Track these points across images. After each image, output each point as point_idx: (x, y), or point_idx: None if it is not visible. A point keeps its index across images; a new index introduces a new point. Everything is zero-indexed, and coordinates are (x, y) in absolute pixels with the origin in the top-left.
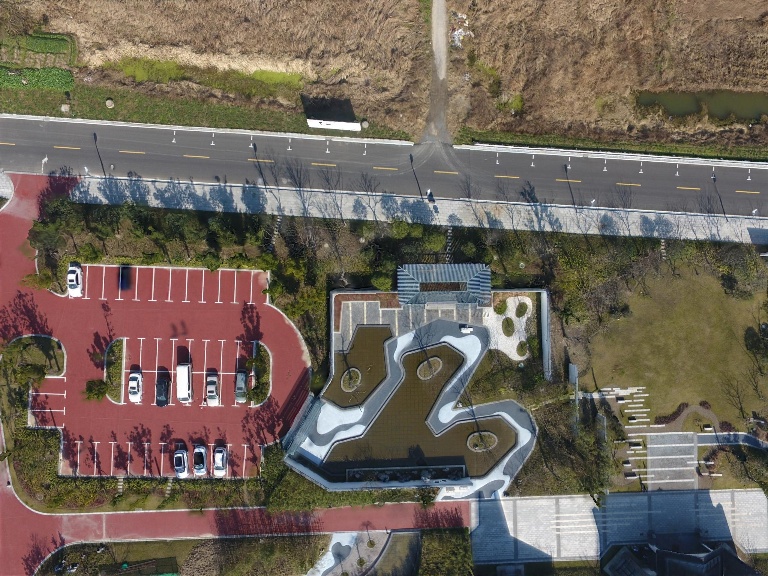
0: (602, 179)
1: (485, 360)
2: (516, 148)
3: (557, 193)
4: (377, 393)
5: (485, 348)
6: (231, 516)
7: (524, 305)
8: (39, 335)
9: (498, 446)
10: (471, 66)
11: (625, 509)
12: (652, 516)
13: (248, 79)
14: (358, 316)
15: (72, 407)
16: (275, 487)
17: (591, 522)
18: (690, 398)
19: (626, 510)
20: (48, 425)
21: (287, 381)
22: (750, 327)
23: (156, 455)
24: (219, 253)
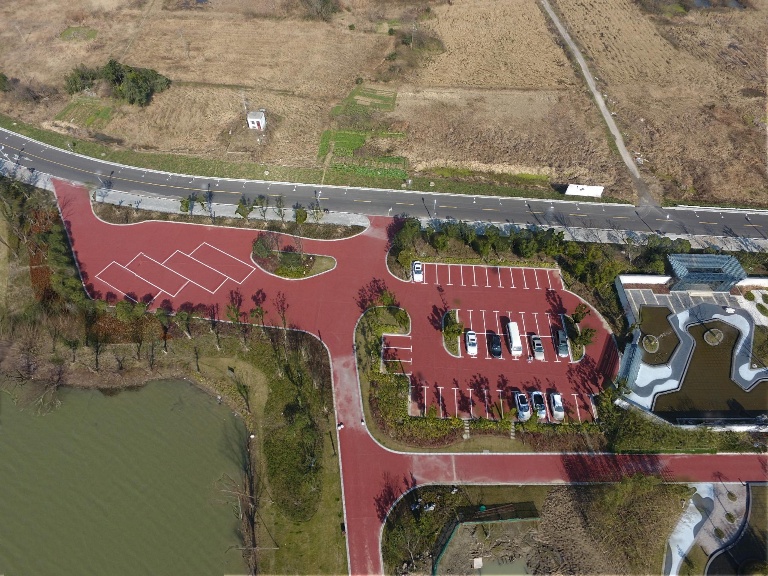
0: None
1: (757, 332)
2: (706, 208)
3: (749, 232)
4: (677, 354)
5: (752, 324)
6: (578, 461)
7: (767, 296)
8: (389, 306)
9: None
10: (654, 173)
11: None
12: None
13: (515, 177)
14: (638, 299)
15: (418, 358)
16: (619, 426)
17: None
18: None
19: None
20: (398, 372)
21: (596, 343)
22: None
23: (495, 400)
24: (520, 258)
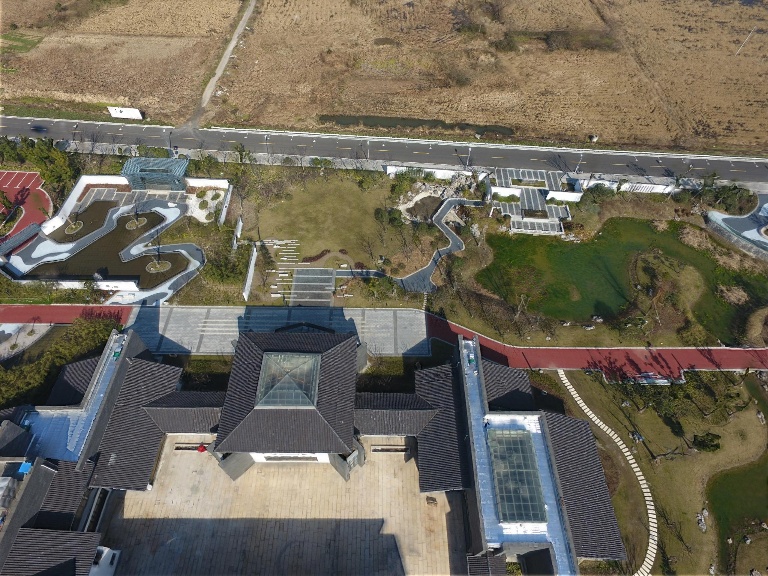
0: (288, 143)
1: (180, 221)
2: (237, 130)
3: (258, 148)
4: (90, 236)
5: (182, 215)
6: None
7: (219, 195)
8: None
9: (171, 270)
10: (223, 103)
11: (267, 318)
12: (290, 324)
13: (90, 105)
14: (98, 196)
15: None
16: None
17: (234, 327)
18: (332, 247)
19: (267, 319)
20: None
21: None
22: (379, 208)
23: None
24: (22, 164)
